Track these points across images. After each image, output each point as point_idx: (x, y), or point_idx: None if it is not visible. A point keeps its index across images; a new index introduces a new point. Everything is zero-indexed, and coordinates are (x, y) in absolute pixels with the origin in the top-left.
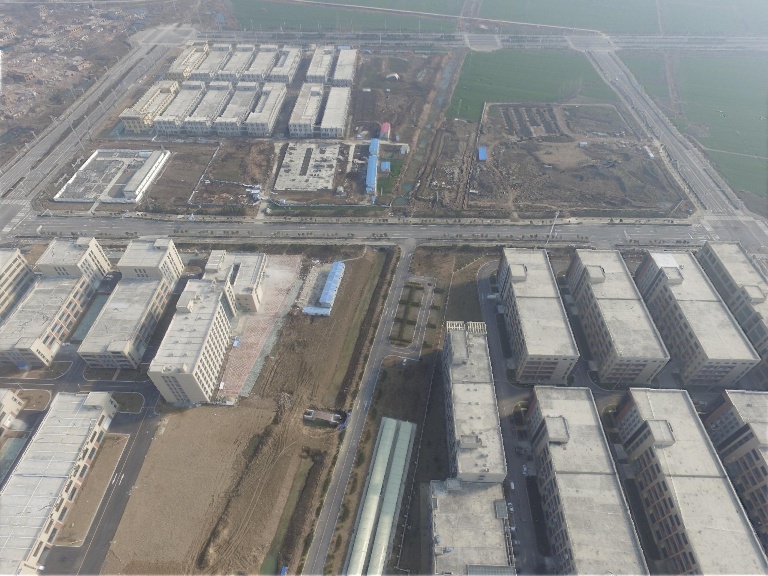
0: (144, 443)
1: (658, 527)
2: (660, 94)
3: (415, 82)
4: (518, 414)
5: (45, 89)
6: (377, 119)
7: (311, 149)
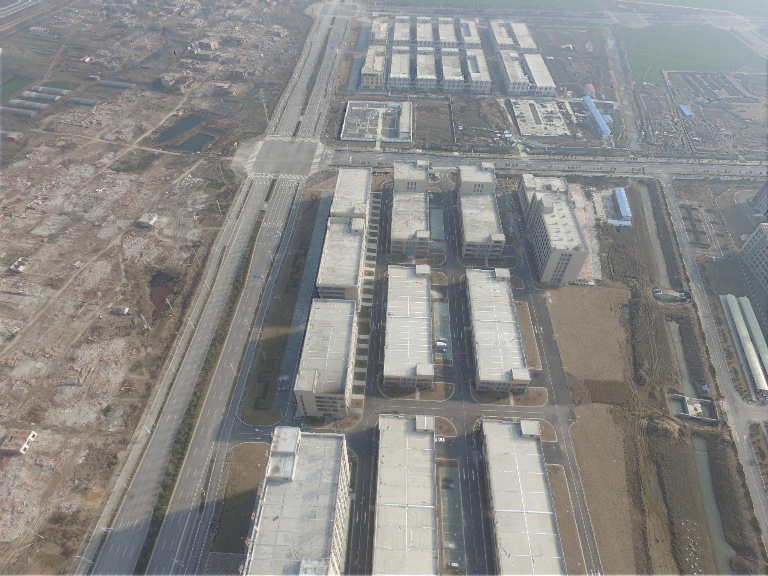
0: (542, 308)
1: None
2: None
3: (589, 52)
4: None
5: (265, 52)
6: (575, 81)
7: (532, 104)
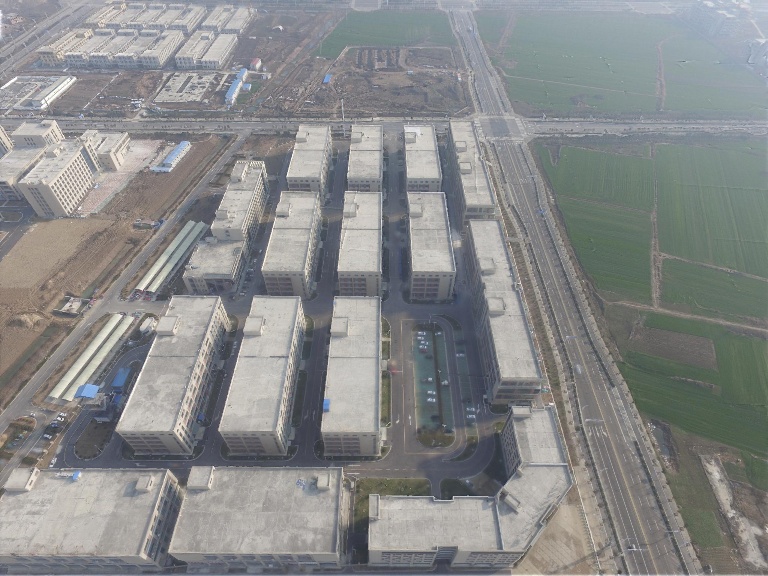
0: (18, 236)
1: None
2: (493, 40)
3: (295, 32)
4: None
5: None
6: (253, 57)
7: (192, 76)
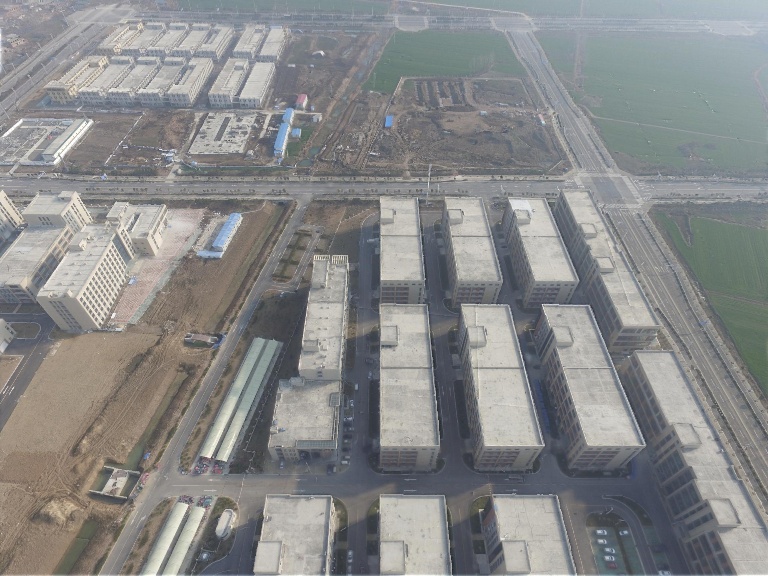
0: (36, 362)
1: (470, 413)
2: (566, 70)
3: (339, 59)
4: (374, 333)
5: None
6: (296, 91)
7: (229, 118)
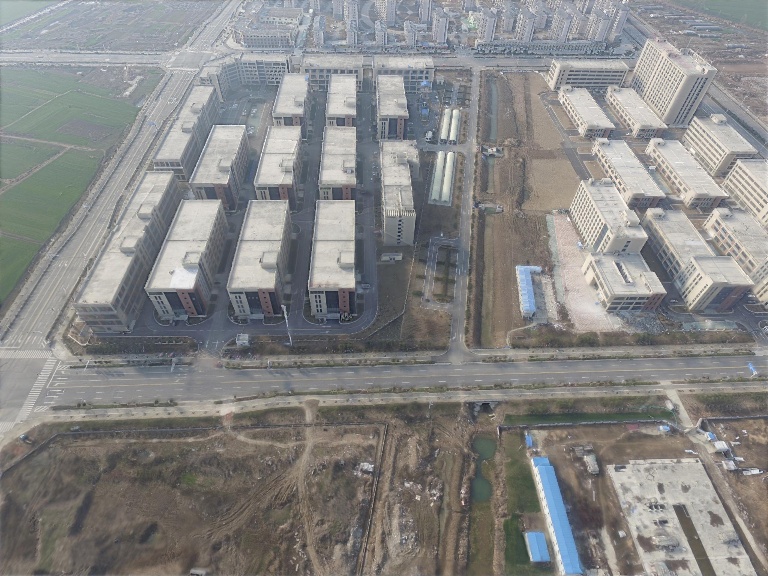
0: None
1: None
2: None
3: None
4: (360, 209)
5: None
6: None
7: None
